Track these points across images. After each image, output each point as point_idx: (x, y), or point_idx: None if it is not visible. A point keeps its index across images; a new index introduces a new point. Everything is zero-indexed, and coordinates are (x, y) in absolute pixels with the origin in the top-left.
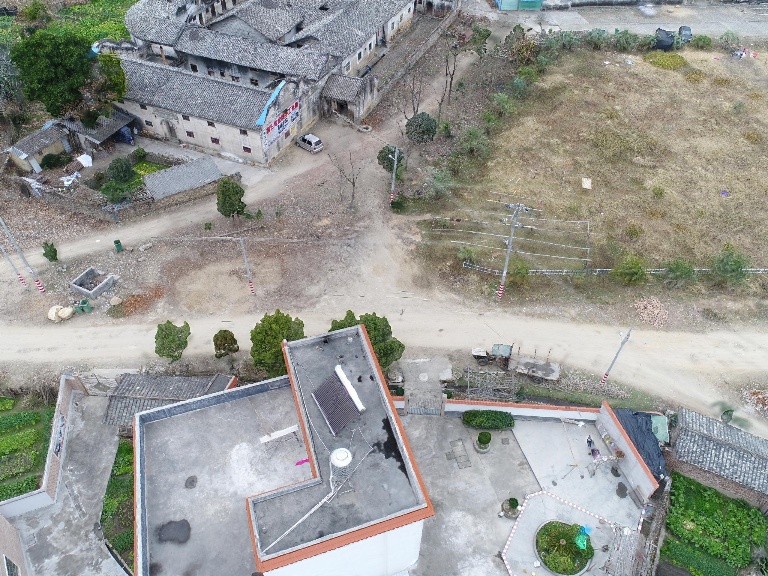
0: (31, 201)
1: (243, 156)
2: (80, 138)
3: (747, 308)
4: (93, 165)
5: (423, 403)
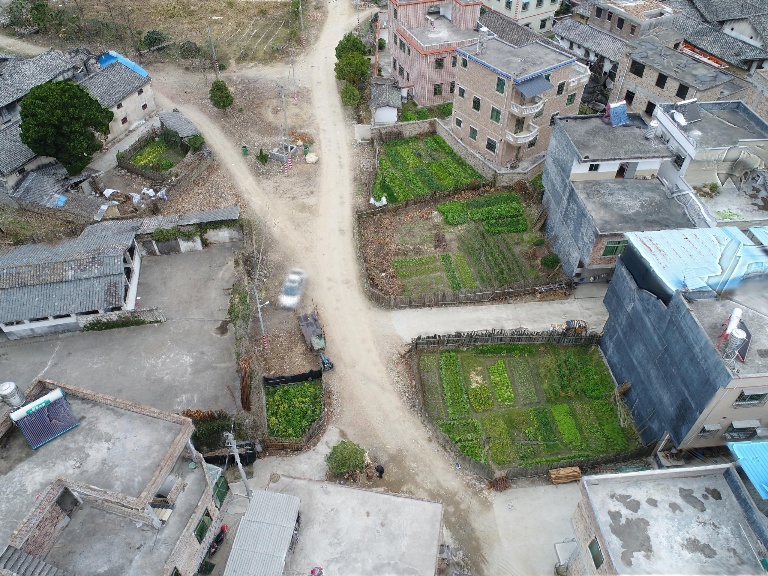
0: (167, 210)
1: (143, 116)
2: (83, 188)
3: (316, 1)
4: (118, 190)
5: None
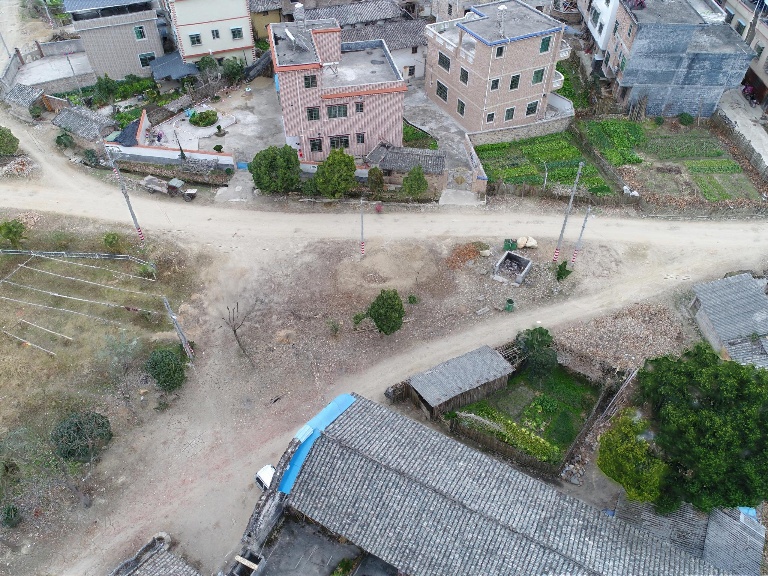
0: None
1: None
2: None
3: None
4: None
5: (247, 158)
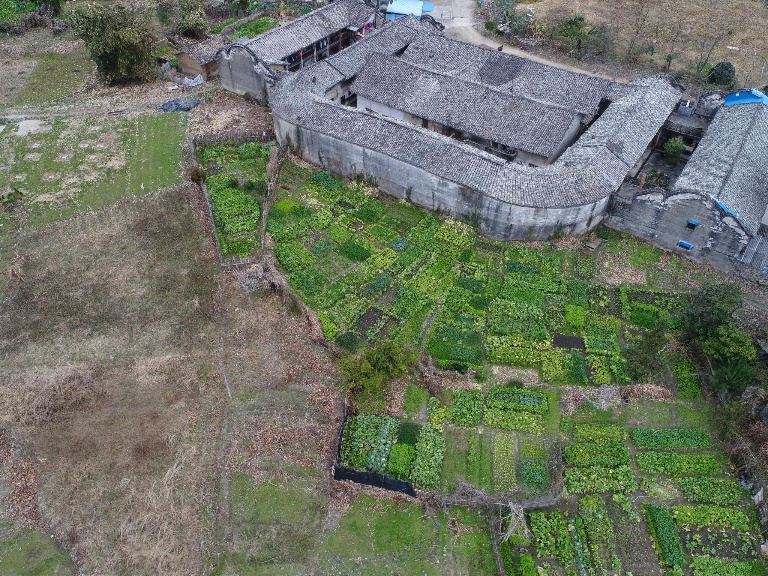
0: None
1: None
2: None
3: None
4: None
5: None
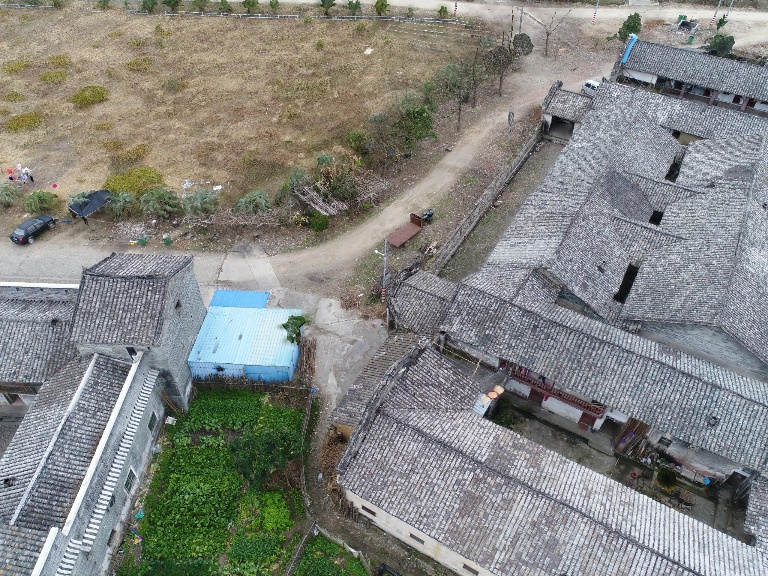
0: None
1: None
2: None
3: None
4: None
5: None
